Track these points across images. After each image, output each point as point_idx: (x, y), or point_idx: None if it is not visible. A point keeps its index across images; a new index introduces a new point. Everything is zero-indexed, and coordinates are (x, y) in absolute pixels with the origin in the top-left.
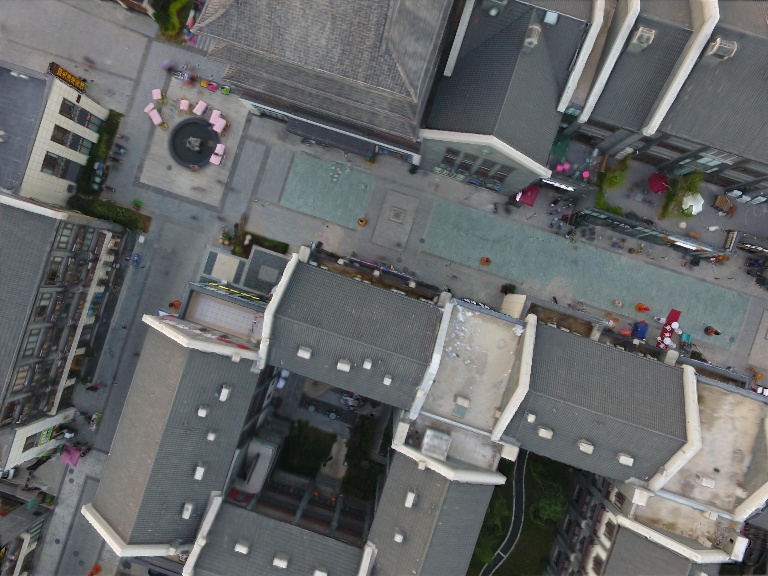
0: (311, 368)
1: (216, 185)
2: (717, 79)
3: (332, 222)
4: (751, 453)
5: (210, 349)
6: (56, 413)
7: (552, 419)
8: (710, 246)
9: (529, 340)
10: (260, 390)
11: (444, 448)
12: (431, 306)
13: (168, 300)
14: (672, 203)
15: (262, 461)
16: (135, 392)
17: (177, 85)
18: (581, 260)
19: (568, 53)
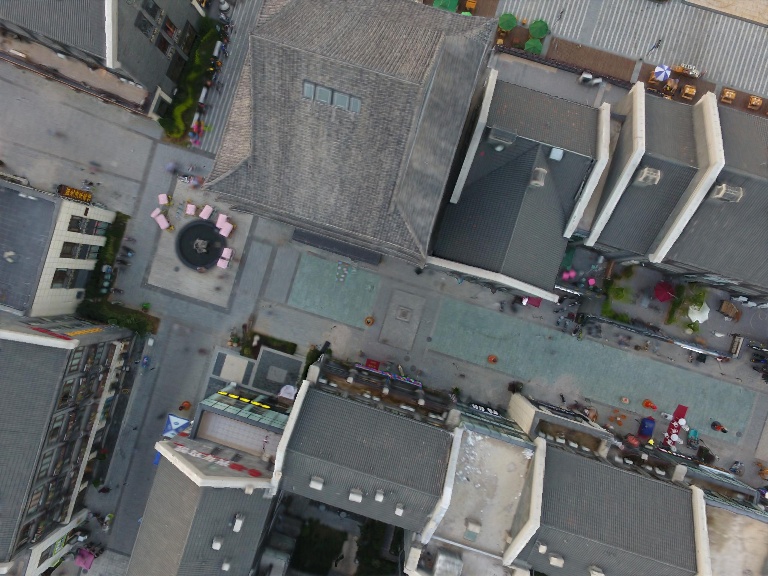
0: (323, 494)
1: (223, 286)
2: (723, 215)
3: (339, 322)
4: (761, 574)
5: (223, 485)
6: (70, 521)
7: (563, 548)
8: (716, 352)
9: (539, 469)
10: (272, 506)
11: (456, 573)
12: (441, 431)
13: (178, 401)
14: (678, 311)
15: (275, 573)
16: (149, 519)
17: (183, 187)
18: (588, 357)
19: (574, 184)
